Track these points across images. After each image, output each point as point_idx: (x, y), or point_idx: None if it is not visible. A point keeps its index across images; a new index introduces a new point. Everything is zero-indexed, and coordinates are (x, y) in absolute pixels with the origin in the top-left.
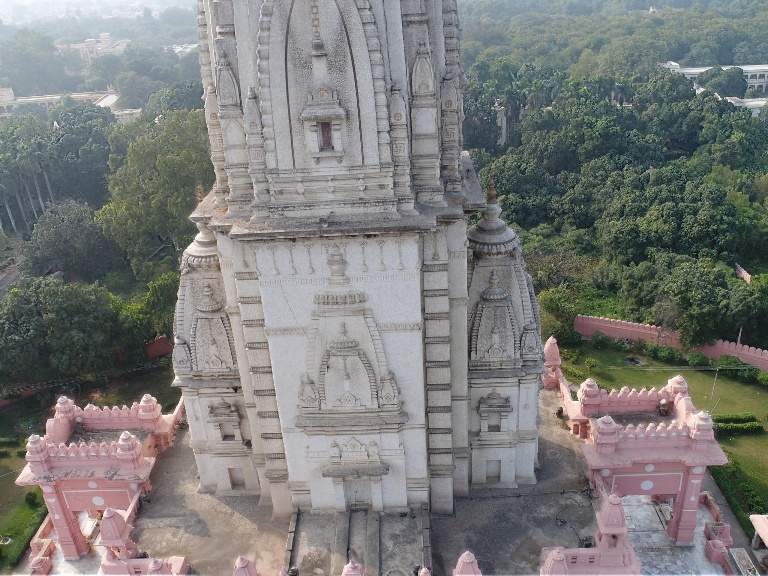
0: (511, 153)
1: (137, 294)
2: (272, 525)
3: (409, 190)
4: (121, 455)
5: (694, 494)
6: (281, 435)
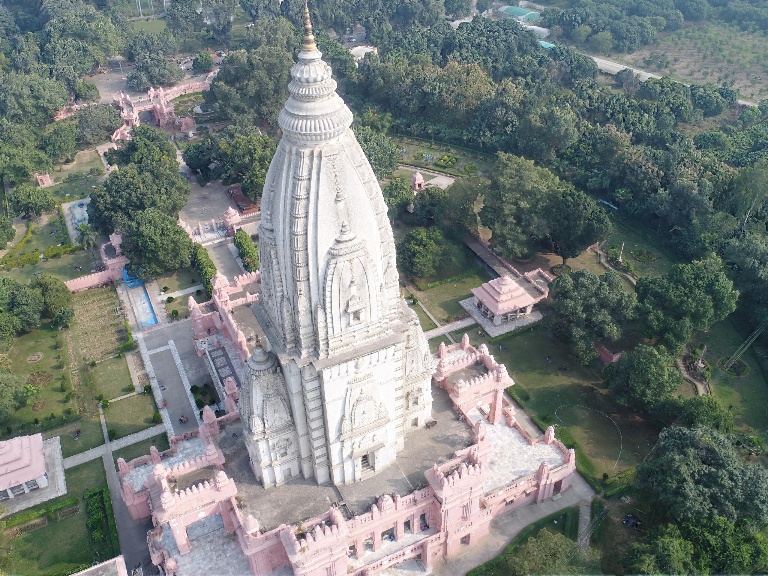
0: None
1: None
2: None
3: None
4: None
5: None
6: None
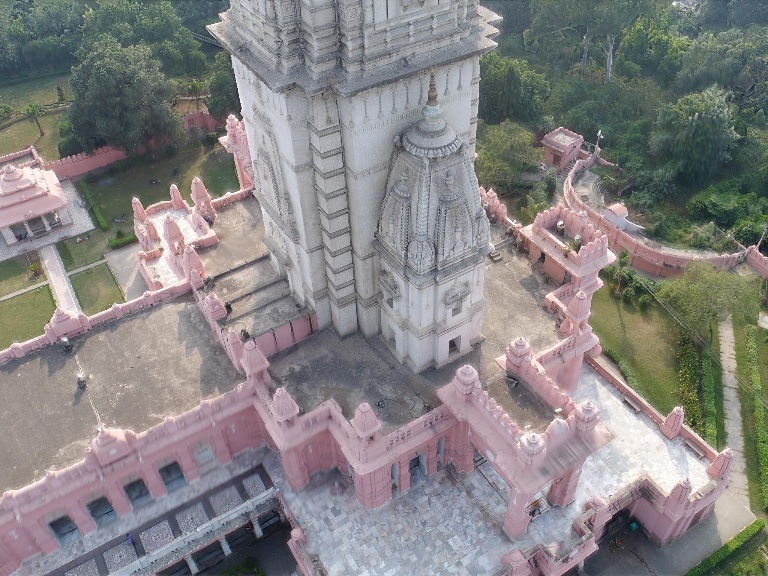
0: None
1: None
2: None
3: (286, 49)
4: None
5: (516, 499)
6: None
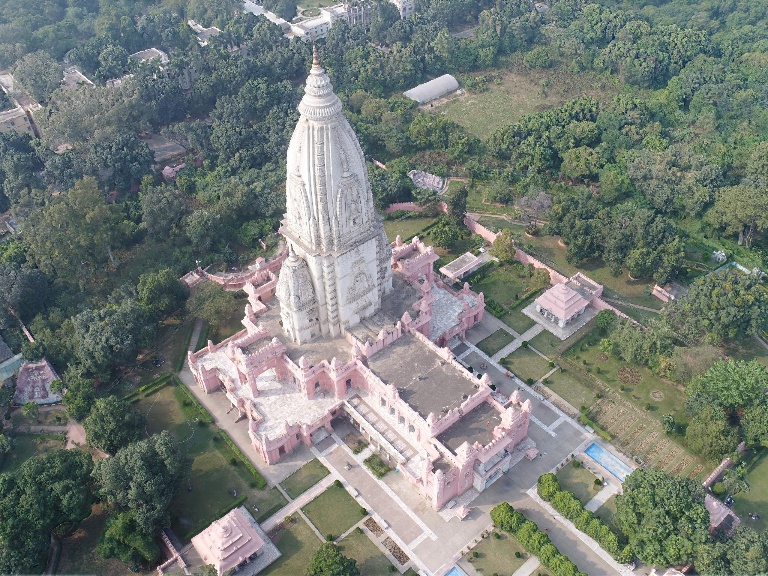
0: (215, 117)
1: (92, 300)
2: (336, 340)
3: (371, 225)
4: (277, 345)
5: (432, 271)
6: (337, 309)
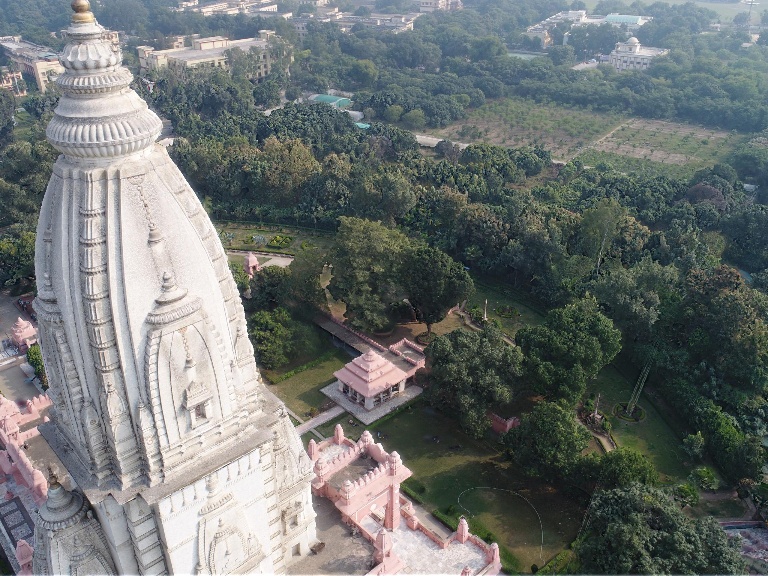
0: None
1: None
2: None
3: None
4: None
5: None
6: None
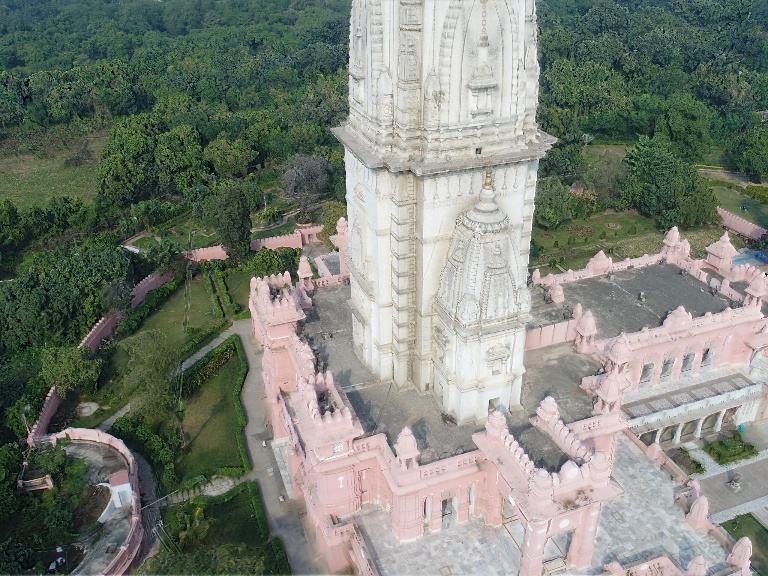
0: None
1: None
2: (524, 363)
3: None
4: None
5: None
6: None
